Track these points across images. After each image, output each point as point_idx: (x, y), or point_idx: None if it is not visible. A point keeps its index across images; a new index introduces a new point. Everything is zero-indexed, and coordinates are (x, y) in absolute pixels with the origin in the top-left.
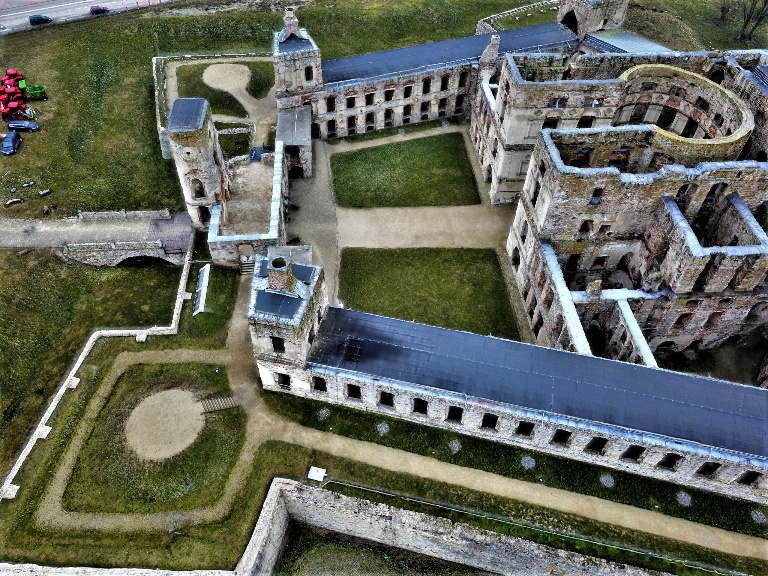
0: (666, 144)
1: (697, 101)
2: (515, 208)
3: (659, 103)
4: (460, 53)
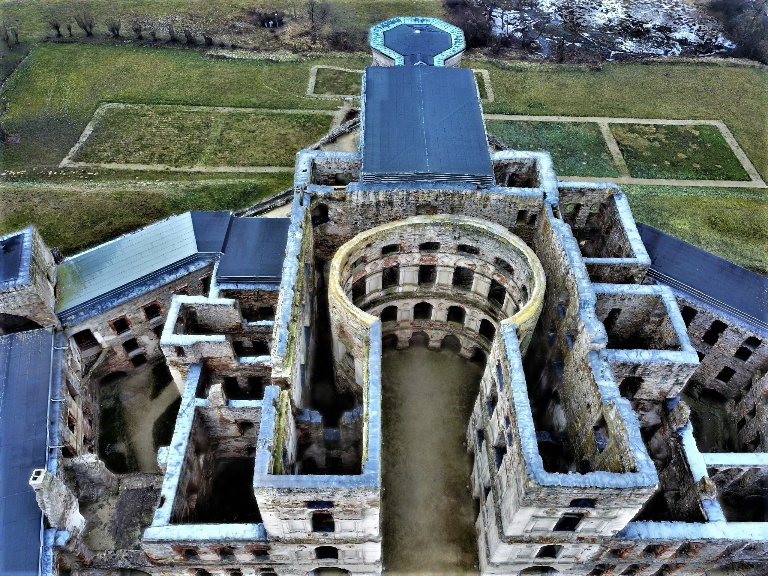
0: (530, 322)
1: (381, 252)
2: (391, 543)
3: (348, 291)
4: (11, 566)
